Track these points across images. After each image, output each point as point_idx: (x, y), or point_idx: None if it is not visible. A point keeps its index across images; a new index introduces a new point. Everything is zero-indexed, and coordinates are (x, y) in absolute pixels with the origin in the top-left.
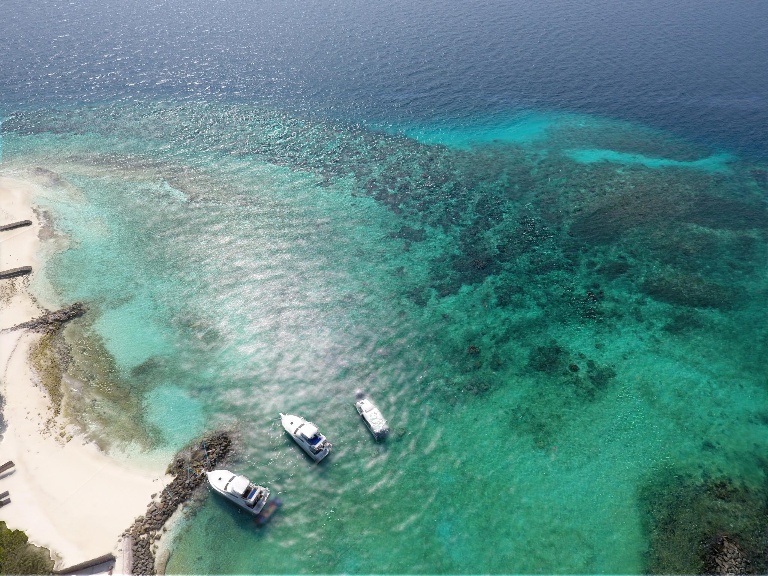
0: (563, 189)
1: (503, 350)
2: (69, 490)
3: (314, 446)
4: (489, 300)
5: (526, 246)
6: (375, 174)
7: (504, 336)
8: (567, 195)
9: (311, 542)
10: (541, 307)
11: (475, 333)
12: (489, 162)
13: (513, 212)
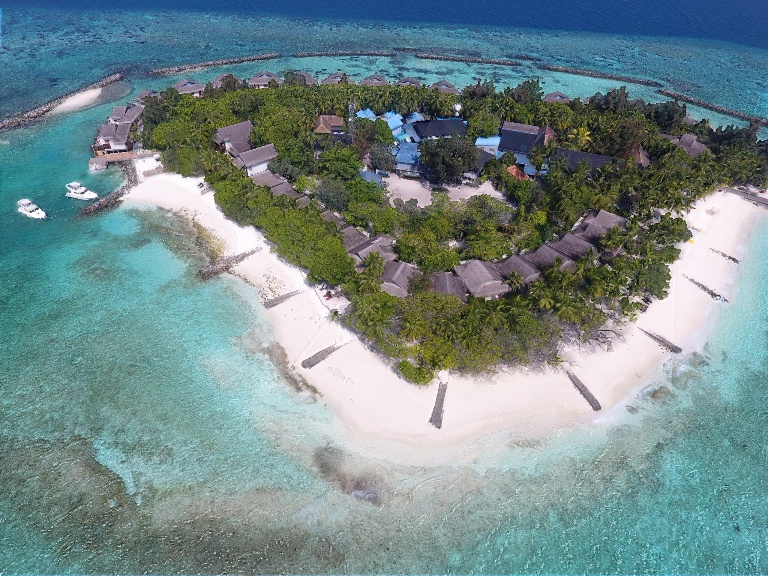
0: None
1: None
2: (173, 193)
3: None
4: None
5: None
6: None
7: None
8: None
9: (52, 187)
10: None
11: None
12: None
13: None
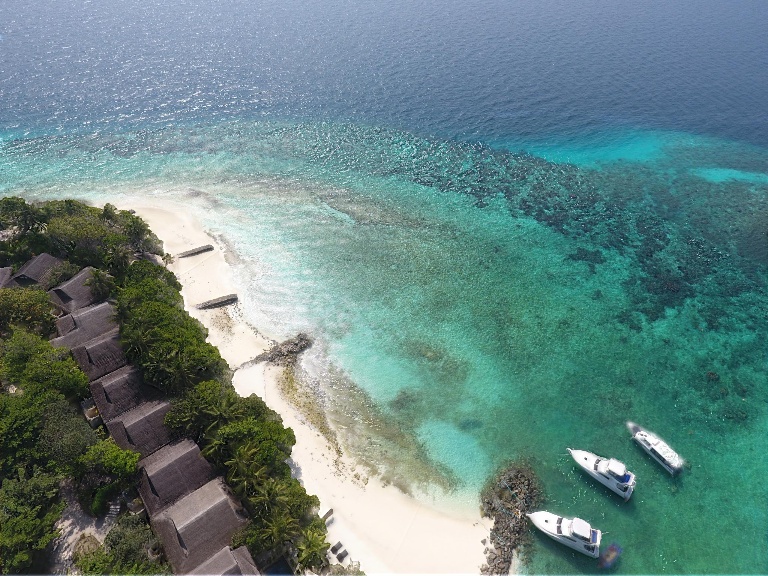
0: (710, 209)
1: (740, 376)
2: (396, 538)
3: (626, 483)
4: (699, 324)
5: (706, 267)
6: (524, 194)
7: (733, 361)
8: (717, 215)
9: None
10: (752, 330)
11: (704, 358)
12: (626, 181)
13: (675, 232)
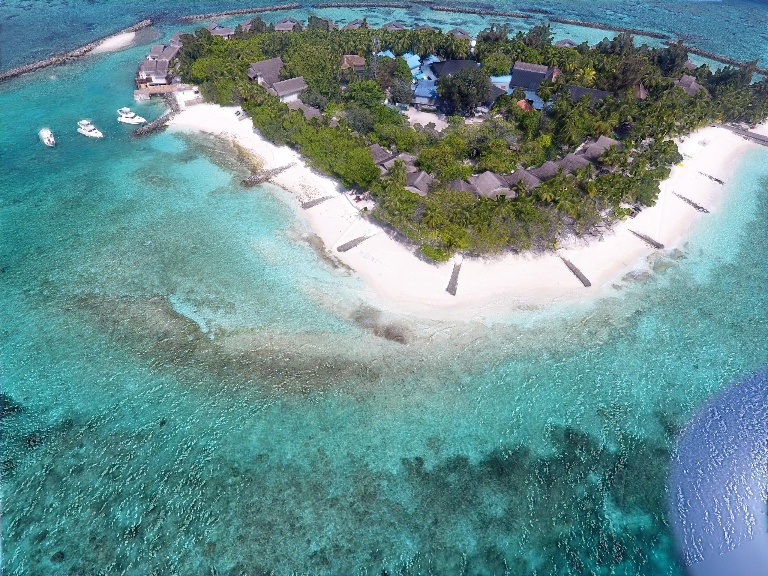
0: None
1: None
2: (212, 120)
3: None
4: None
5: None
6: None
7: None
8: None
9: (103, 114)
10: None
11: None
12: None
13: None
